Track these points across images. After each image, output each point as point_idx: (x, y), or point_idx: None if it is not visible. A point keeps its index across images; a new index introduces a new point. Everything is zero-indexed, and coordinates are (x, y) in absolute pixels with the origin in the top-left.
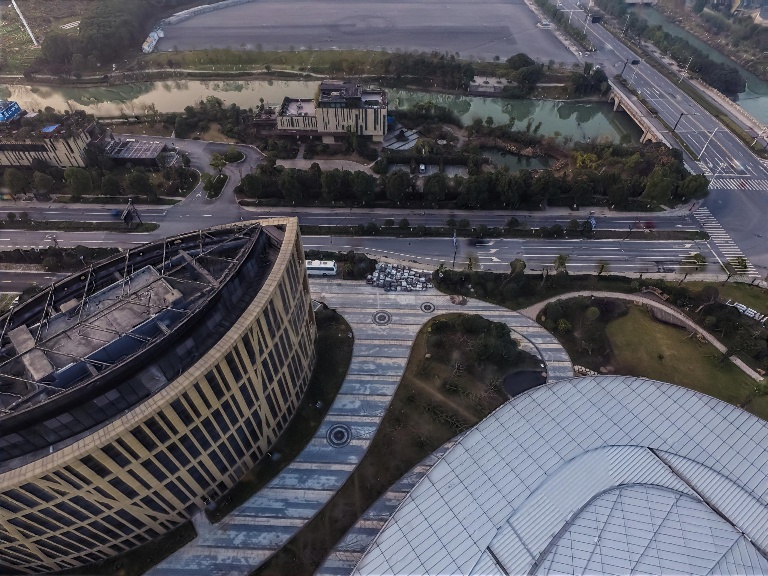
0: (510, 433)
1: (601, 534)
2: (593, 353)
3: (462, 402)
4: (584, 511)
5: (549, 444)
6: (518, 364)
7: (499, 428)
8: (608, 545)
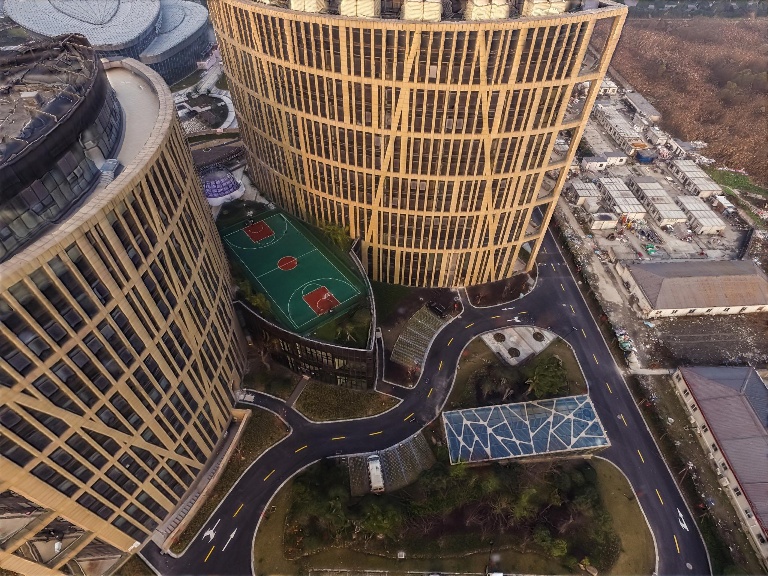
0: (14, 6)
1: (58, 0)
2: (17, 40)
3: (4, 65)
4: (50, 1)
5: (26, 2)
6: (1, 54)
7: (10, 7)
8: (62, 0)
